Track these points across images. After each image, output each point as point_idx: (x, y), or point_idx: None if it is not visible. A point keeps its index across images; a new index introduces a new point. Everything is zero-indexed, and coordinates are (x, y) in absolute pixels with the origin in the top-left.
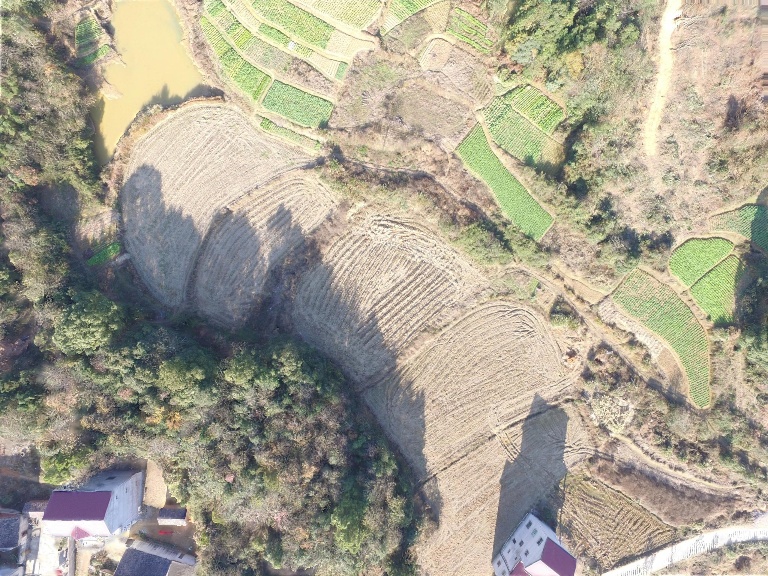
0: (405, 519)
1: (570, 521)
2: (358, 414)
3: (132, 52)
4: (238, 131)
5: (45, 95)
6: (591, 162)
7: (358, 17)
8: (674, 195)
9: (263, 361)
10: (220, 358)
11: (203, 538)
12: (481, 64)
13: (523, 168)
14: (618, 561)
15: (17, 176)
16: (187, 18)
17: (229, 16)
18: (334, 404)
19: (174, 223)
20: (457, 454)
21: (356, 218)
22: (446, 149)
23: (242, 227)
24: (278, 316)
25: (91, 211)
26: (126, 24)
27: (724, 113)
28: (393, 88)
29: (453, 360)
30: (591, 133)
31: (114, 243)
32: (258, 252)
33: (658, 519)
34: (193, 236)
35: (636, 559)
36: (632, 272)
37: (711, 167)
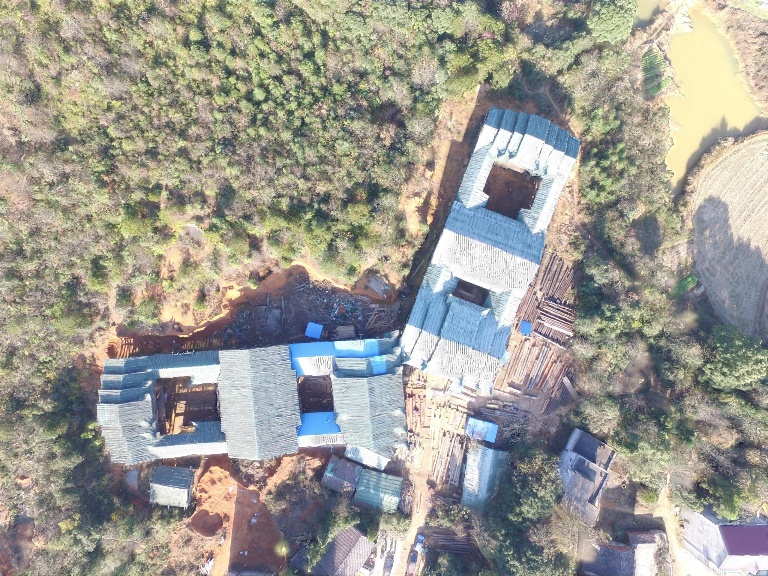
0: None
1: None
2: None
3: (690, 84)
4: None
5: (646, 129)
6: None
7: None
8: None
9: None
10: None
11: None
12: None
13: None
14: None
15: None
16: (749, 51)
17: None
18: None
19: (743, 254)
20: None
21: None
22: None
23: None
24: None
25: (671, 243)
26: (682, 56)
27: None
28: None
29: None
30: None
31: (692, 275)
32: None
33: None
34: (762, 267)
35: None
36: None
37: None
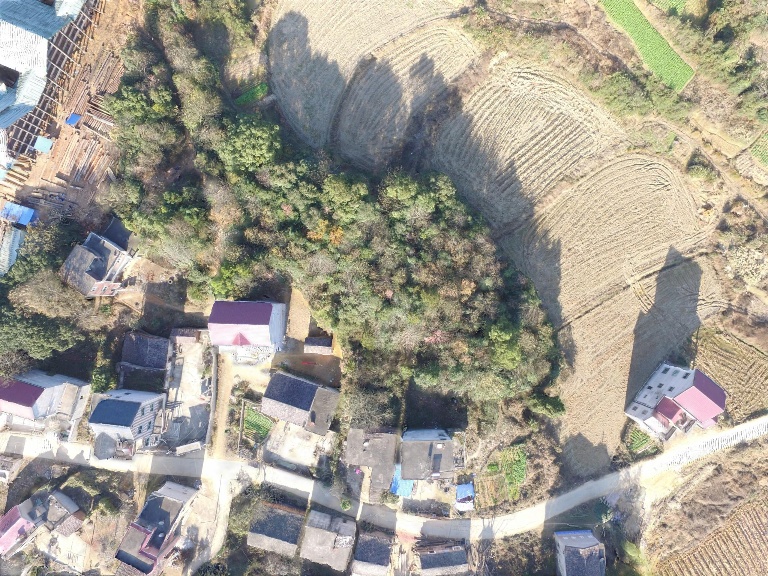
0: (553, 348)
1: None
2: None
3: None
4: None
5: None
6: (739, 9)
7: None
8: None
9: (421, 184)
10: None
11: (350, 364)
12: None
13: (668, 18)
14: (750, 415)
15: (179, 5)
16: None
17: None
18: (485, 234)
19: (319, 67)
20: (592, 302)
21: (497, 69)
22: (589, 1)
23: (385, 74)
24: (418, 162)
25: (241, 51)
26: None
27: None
28: None
29: (589, 210)
30: None
31: (262, 83)
32: (400, 99)
33: None
34: (338, 80)
35: None
36: None
37: None
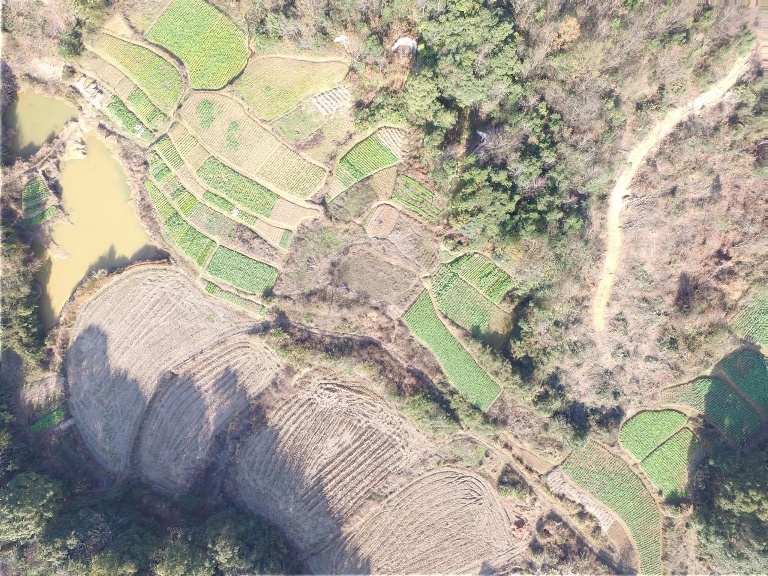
0: None
1: None
2: None
3: (79, 212)
4: (184, 294)
5: None
6: (537, 340)
7: (302, 187)
8: (624, 370)
9: (198, 549)
10: (158, 538)
11: None
12: (428, 231)
13: (469, 340)
14: None
15: None
16: (134, 179)
17: (174, 181)
18: None
19: (119, 387)
20: None
21: (302, 382)
22: (392, 316)
23: (187, 391)
24: (222, 481)
25: (36, 377)
26: (74, 183)
27: (675, 291)
28: (338, 254)
29: (399, 527)
30: (536, 313)
31: (58, 409)
32: (203, 416)
33: None
34: (138, 400)
35: None
36: None
37: (661, 344)
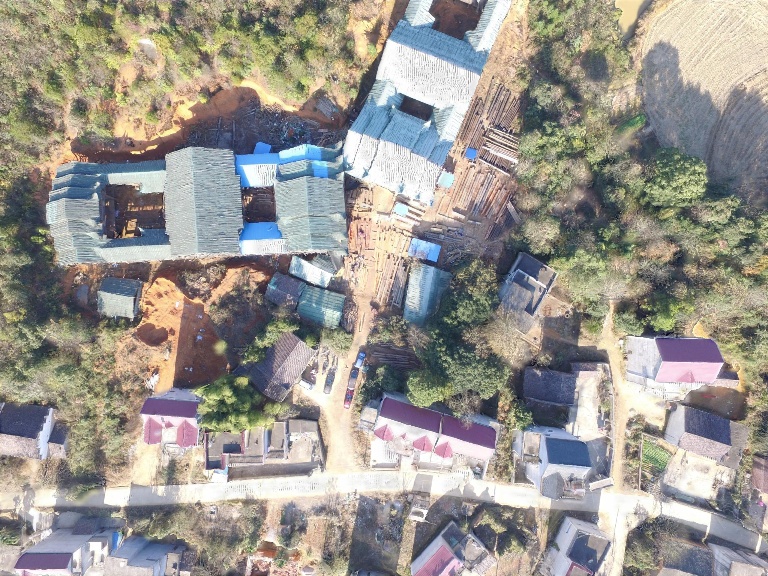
0: None
1: None
2: None
3: None
4: (751, 11)
5: None
6: None
7: None
8: None
9: None
10: None
11: (763, 397)
12: None
13: None
14: None
15: (581, 39)
16: None
17: None
18: None
19: (692, 98)
20: None
21: None
22: None
23: (756, 104)
24: None
25: (619, 83)
26: None
27: None
28: None
29: None
30: None
31: (641, 115)
32: None
33: None
34: (711, 111)
35: None
36: None
37: None
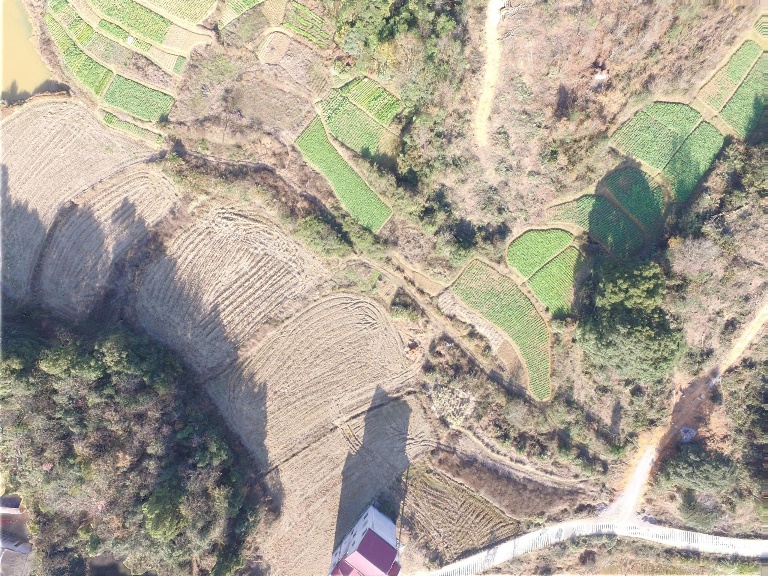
0: (229, 509)
1: (412, 513)
2: (191, 405)
3: None
4: (83, 126)
5: None
6: (421, 153)
7: (193, 11)
8: (508, 186)
9: (85, 351)
10: None
11: (34, 526)
12: (318, 57)
13: (357, 160)
14: (460, 554)
15: None
16: (34, 15)
17: (71, 12)
18: (160, 394)
19: (20, 217)
20: (298, 446)
21: (200, 211)
22: (285, 142)
23: (87, 220)
24: (122, 308)
25: None
26: None
27: (554, 103)
28: (232, 81)
29: (295, 352)
30: (417, 124)
31: None
32: (102, 245)
33: (501, 512)
34: (38, 229)
35: (478, 552)
36: (472, 264)
37: (543, 158)
